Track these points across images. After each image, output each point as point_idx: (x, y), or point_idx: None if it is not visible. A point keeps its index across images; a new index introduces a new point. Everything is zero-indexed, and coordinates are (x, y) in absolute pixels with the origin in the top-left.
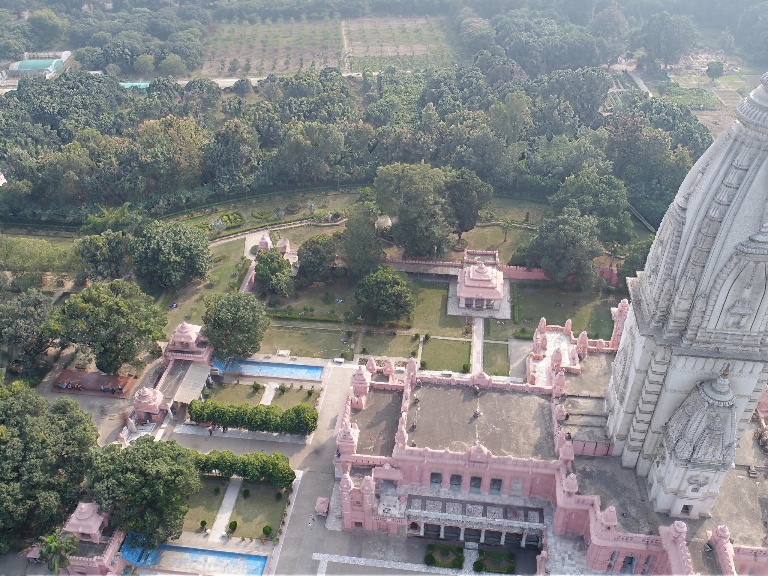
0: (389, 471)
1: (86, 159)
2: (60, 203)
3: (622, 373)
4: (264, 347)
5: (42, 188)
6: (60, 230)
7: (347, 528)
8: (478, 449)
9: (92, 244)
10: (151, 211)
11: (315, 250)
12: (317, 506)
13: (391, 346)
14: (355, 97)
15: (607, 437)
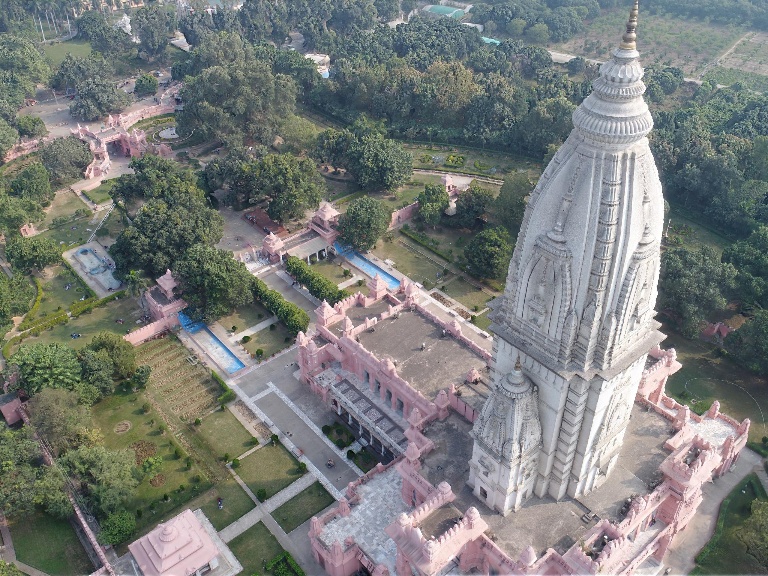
0: (336, 350)
1: (382, 79)
2: (351, 107)
3: None
4: (382, 252)
5: (348, 92)
6: (341, 126)
7: (302, 380)
8: (385, 361)
9: (326, 134)
10: (403, 133)
11: (469, 198)
12: (297, 355)
13: (468, 296)
14: (661, 98)
15: None
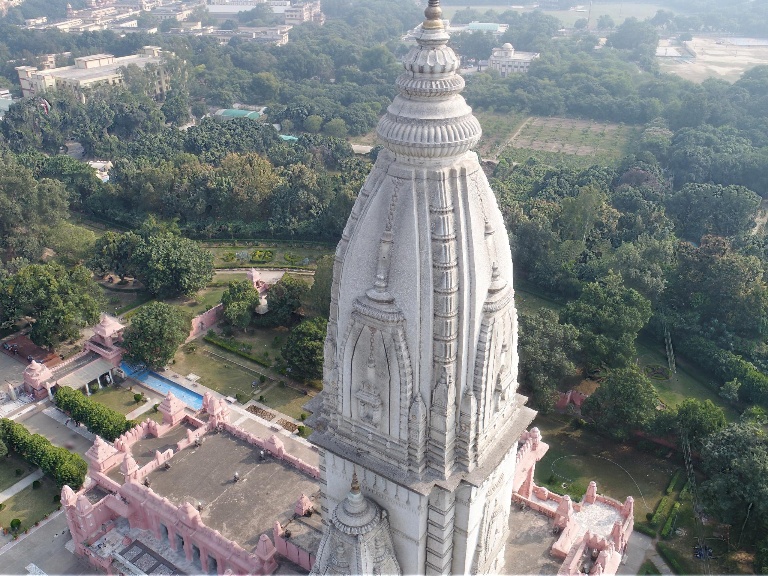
0: (119, 503)
1: (171, 177)
2: (138, 210)
3: None
4: (183, 367)
5: (133, 195)
6: None
7: (77, 552)
8: (184, 507)
9: (104, 238)
10: (200, 232)
11: (280, 291)
12: None
13: (292, 403)
14: None
15: None
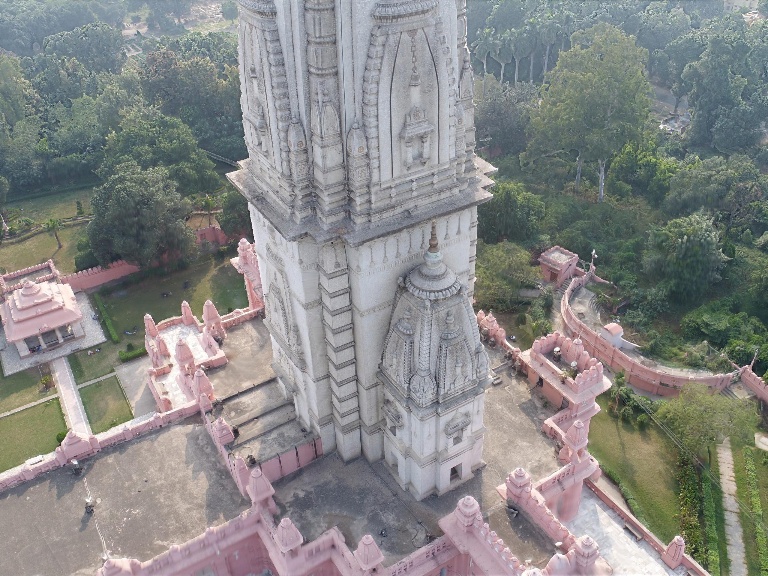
0: None
1: None
2: None
3: (285, 324)
4: None
5: None
6: None
7: None
8: (109, 571)
9: None
10: None
11: None
12: None
13: None
14: None
15: (305, 431)
